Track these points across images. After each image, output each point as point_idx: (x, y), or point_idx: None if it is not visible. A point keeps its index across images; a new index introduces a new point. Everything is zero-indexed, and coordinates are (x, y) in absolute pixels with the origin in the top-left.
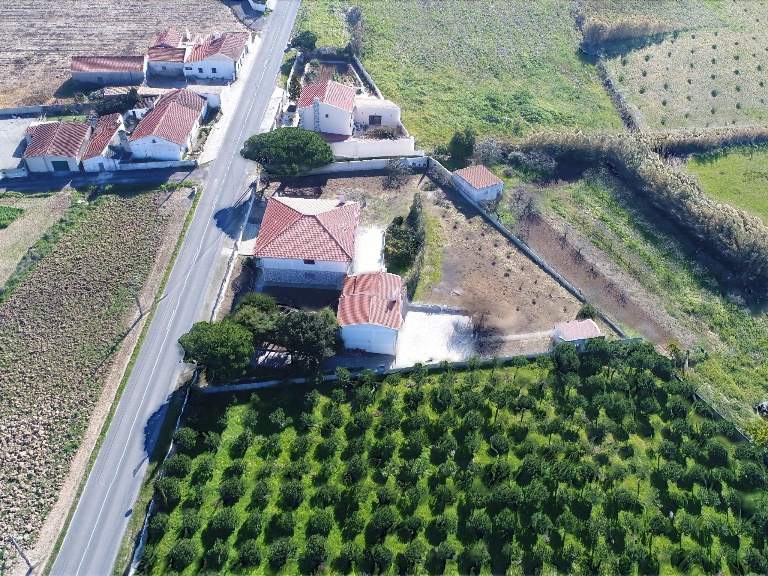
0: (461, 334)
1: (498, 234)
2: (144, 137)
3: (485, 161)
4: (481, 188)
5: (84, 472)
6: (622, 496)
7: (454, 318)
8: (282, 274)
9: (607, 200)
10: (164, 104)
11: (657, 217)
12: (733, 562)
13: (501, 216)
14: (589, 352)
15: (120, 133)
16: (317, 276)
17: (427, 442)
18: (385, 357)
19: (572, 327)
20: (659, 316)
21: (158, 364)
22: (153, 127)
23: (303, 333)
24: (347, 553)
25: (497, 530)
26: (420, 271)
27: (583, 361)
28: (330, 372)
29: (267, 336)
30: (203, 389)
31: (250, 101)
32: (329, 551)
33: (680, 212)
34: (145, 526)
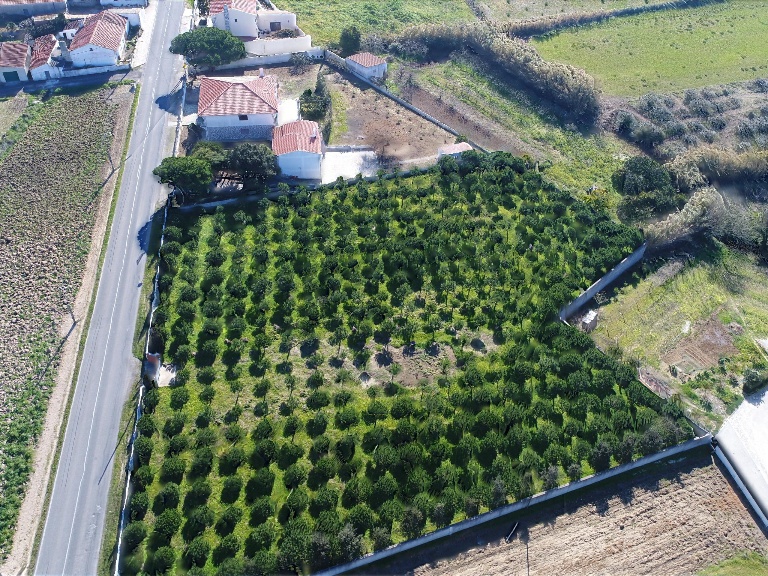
0: (369, 162)
1: (388, 99)
2: (82, 46)
3: (370, 52)
4: (370, 67)
5: (97, 267)
6: (495, 235)
7: (362, 153)
8: (222, 132)
9: (470, 73)
10: (92, 22)
11: (509, 79)
12: (574, 268)
13: (389, 87)
14: (465, 159)
15: (61, 44)
16: (251, 131)
17: (354, 225)
18: (313, 181)
19: (451, 148)
20: (516, 143)
21: (136, 198)
22: (88, 38)
23: (250, 157)
24: (308, 289)
25: (412, 264)
26: (331, 125)
27: (461, 166)
28: (274, 186)
29: (221, 166)
30: (178, 207)
31: (165, 20)
32: (295, 290)
33: (525, 73)
34: (156, 287)
